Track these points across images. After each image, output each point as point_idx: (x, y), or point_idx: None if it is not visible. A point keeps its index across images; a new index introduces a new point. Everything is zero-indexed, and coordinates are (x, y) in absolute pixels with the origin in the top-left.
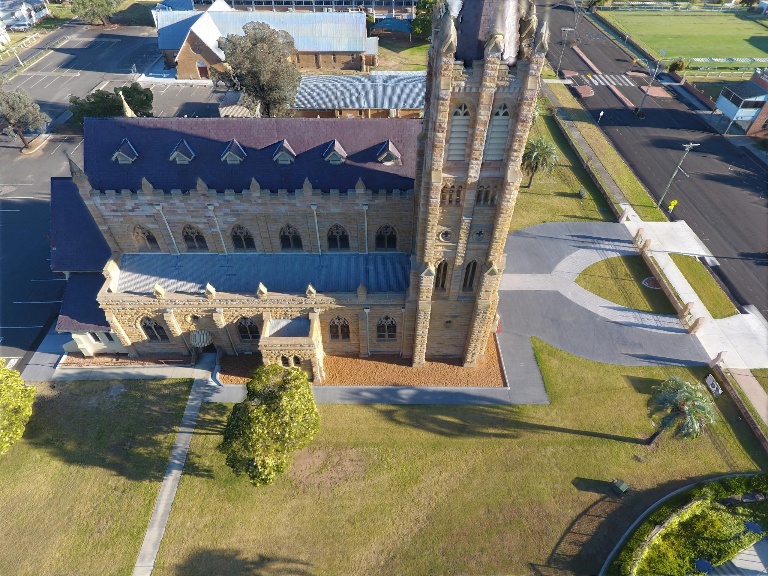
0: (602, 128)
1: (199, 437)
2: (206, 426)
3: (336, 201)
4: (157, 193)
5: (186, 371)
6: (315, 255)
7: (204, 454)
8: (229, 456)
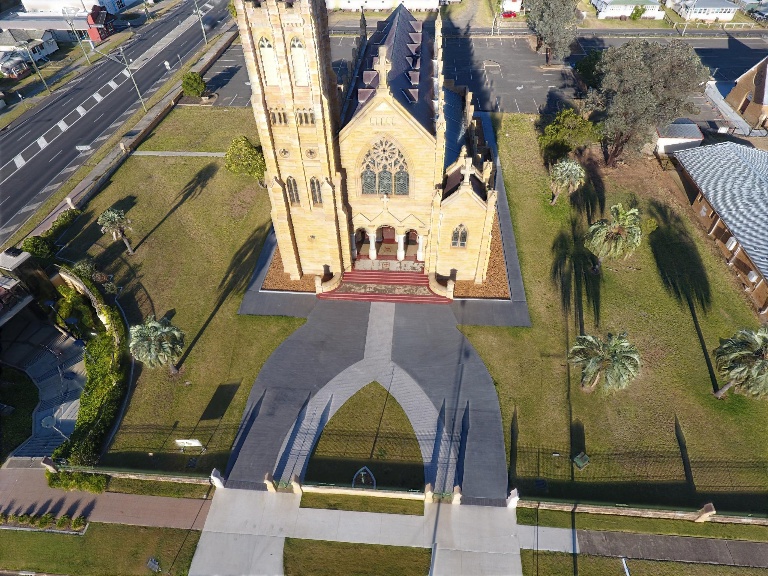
0: None
1: None
2: None
3: None
4: None
5: None
6: None
7: None
8: None
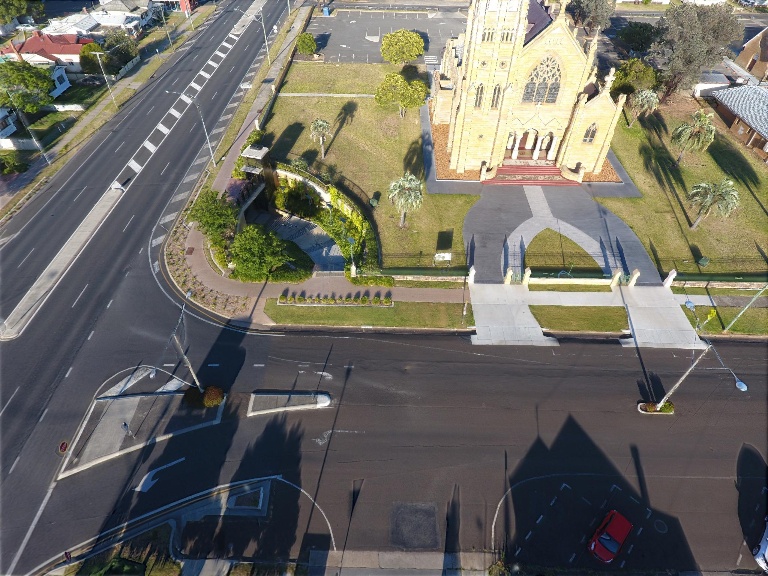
0: None
1: None
2: None
3: None
4: None
5: None
6: None
7: None
8: None
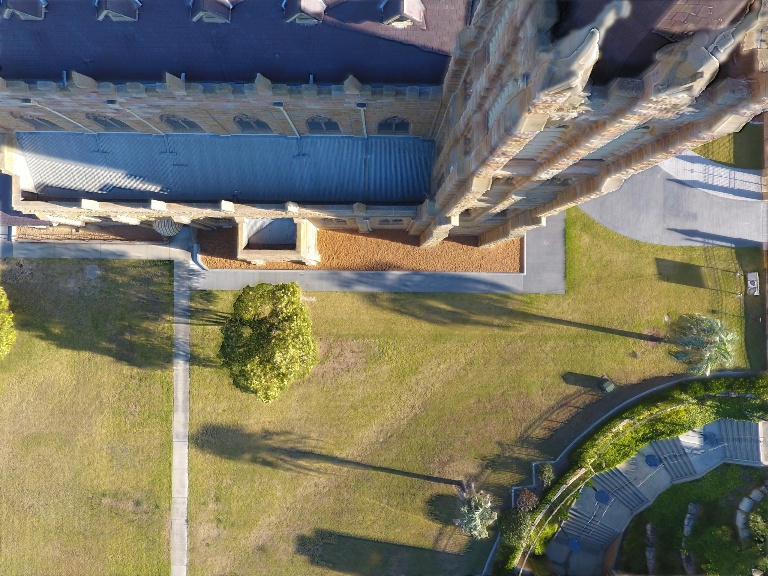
0: None
1: (197, 328)
2: (201, 317)
3: (314, 100)
4: (16, 89)
5: (161, 251)
6: (291, 137)
7: (206, 346)
8: (232, 375)
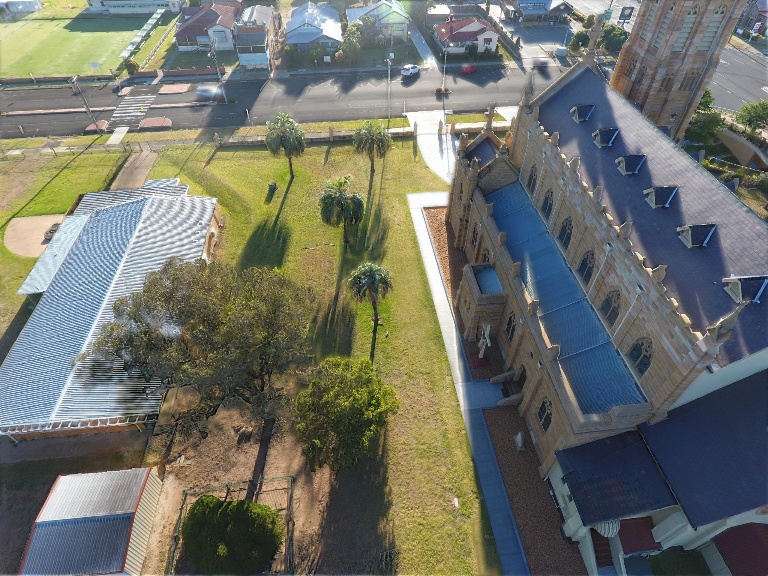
0: (248, 125)
1: None
2: None
3: None
4: None
5: None
6: None
7: None
8: None
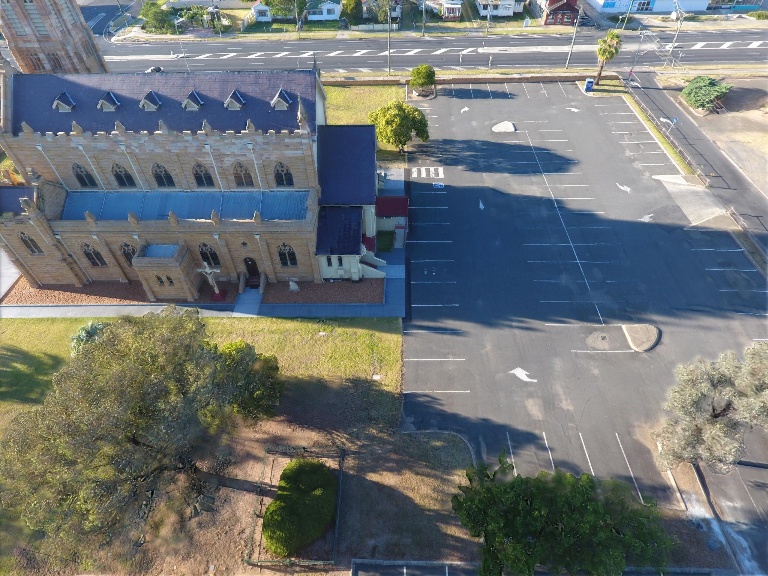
0: None
1: None
2: None
3: None
4: None
5: None
6: None
7: None
8: None
